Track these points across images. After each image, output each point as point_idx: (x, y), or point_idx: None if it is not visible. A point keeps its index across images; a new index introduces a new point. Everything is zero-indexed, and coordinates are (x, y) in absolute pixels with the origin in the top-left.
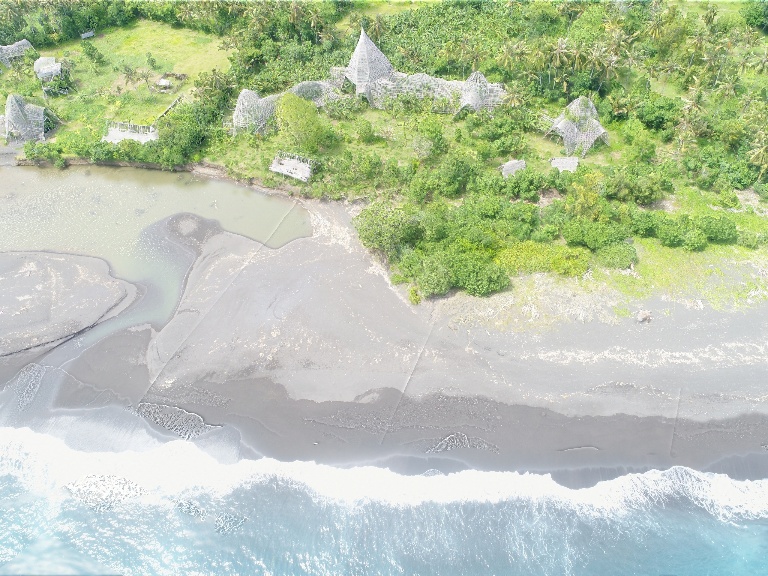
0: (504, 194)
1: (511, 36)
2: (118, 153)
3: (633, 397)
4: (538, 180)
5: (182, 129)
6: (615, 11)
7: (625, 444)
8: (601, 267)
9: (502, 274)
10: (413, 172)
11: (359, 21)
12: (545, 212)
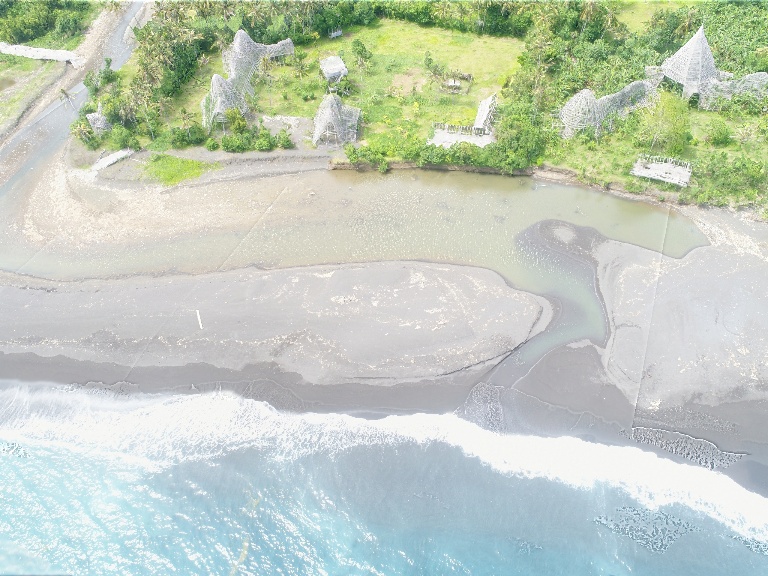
0: None
1: None
2: (452, 156)
3: None
4: None
5: (527, 131)
6: None
7: None
8: None
9: None
10: None
11: (663, 18)
12: None
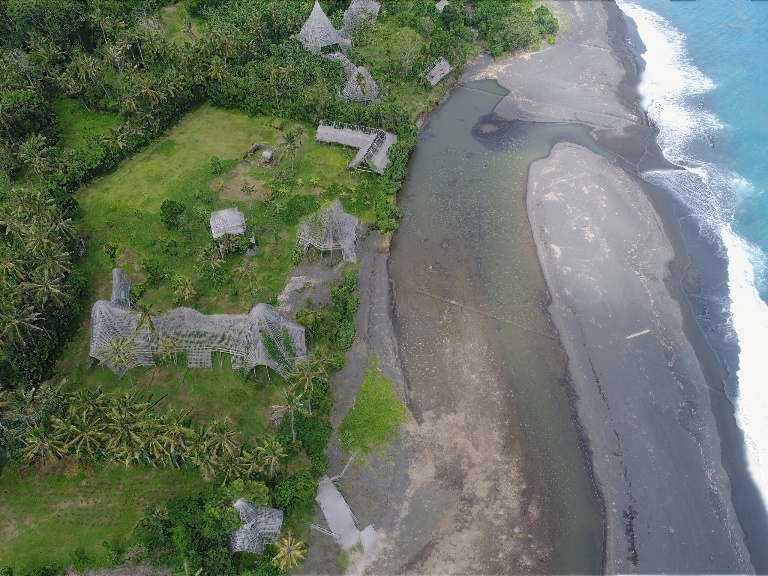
0: None
1: None
2: None
3: (594, 4)
4: None
5: None
6: None
7: (616, 10)
8: None
9: None
10: None
11: None
12: None
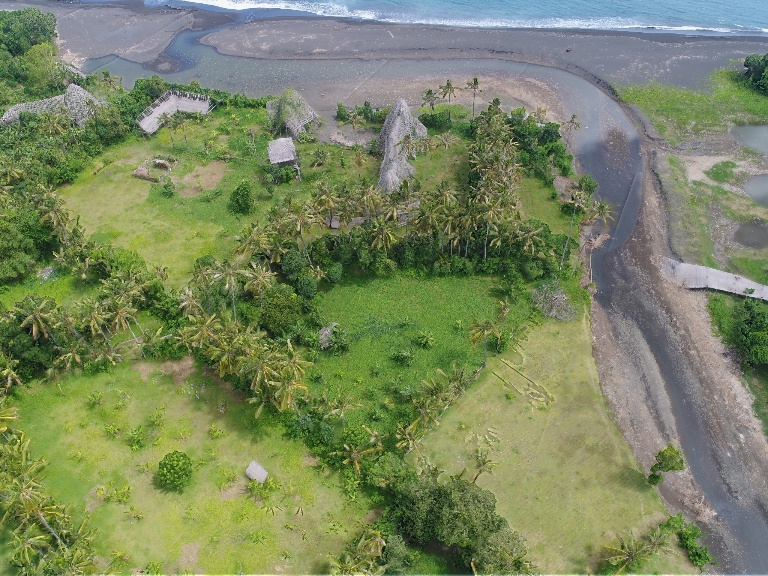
0: None
1: None
2: None
3: None
4: None
5: None
6: None
7: None
8: None
9: None
10: None
11: None
12: None
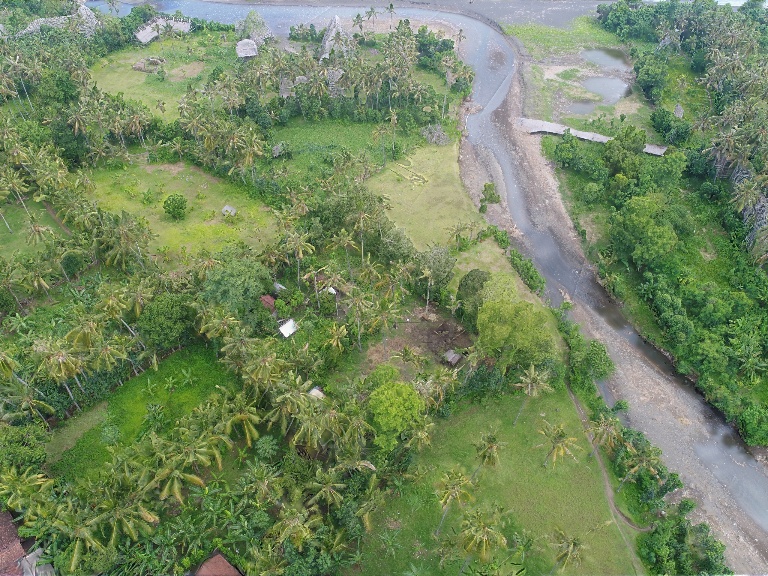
0: None
1: None
2: None
3: None
4: None
5: None
6: None
7: None
8: None
9: None
10: (10, 5)
11: None
12: None
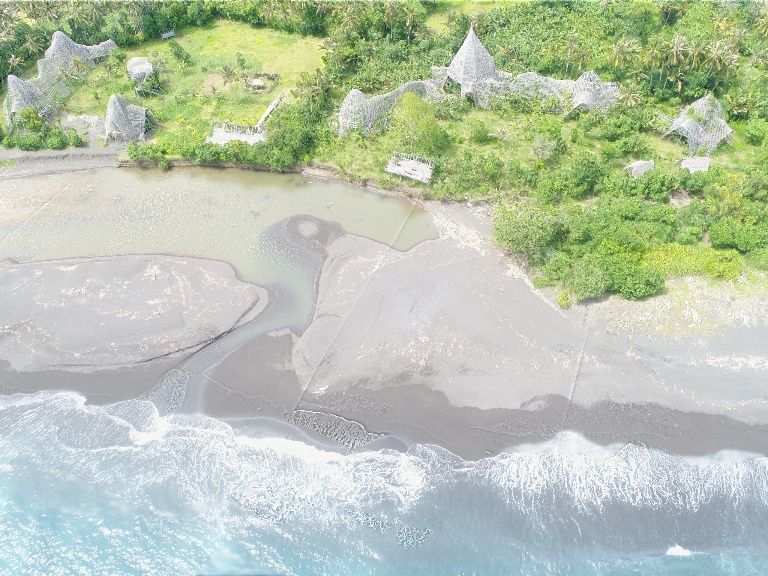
0: (633, 195)
1: (606, 35)
2: (225, 154)
3: None
4: (670, 181)
5: (293, 129)
6: (725, 9)
7: None
8: (754, 270)
9: (659, 277)
10: (535, 173)
11: (457, 20)
12: (683, 213)
